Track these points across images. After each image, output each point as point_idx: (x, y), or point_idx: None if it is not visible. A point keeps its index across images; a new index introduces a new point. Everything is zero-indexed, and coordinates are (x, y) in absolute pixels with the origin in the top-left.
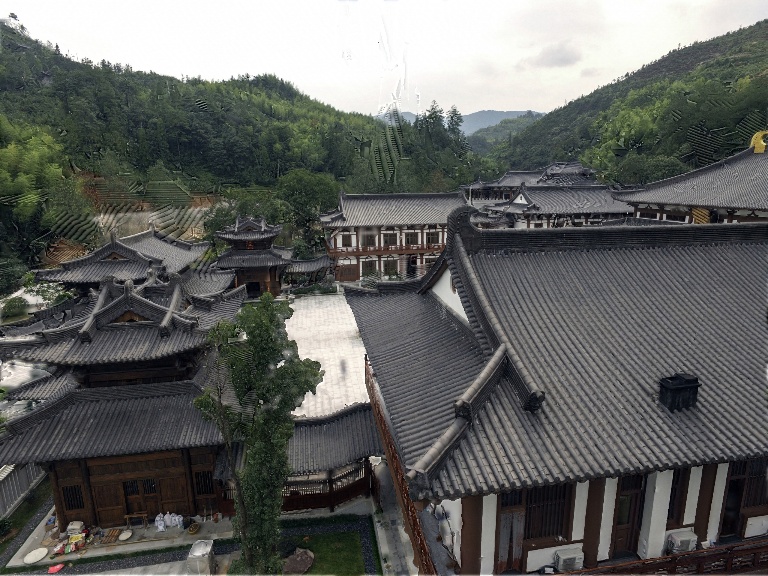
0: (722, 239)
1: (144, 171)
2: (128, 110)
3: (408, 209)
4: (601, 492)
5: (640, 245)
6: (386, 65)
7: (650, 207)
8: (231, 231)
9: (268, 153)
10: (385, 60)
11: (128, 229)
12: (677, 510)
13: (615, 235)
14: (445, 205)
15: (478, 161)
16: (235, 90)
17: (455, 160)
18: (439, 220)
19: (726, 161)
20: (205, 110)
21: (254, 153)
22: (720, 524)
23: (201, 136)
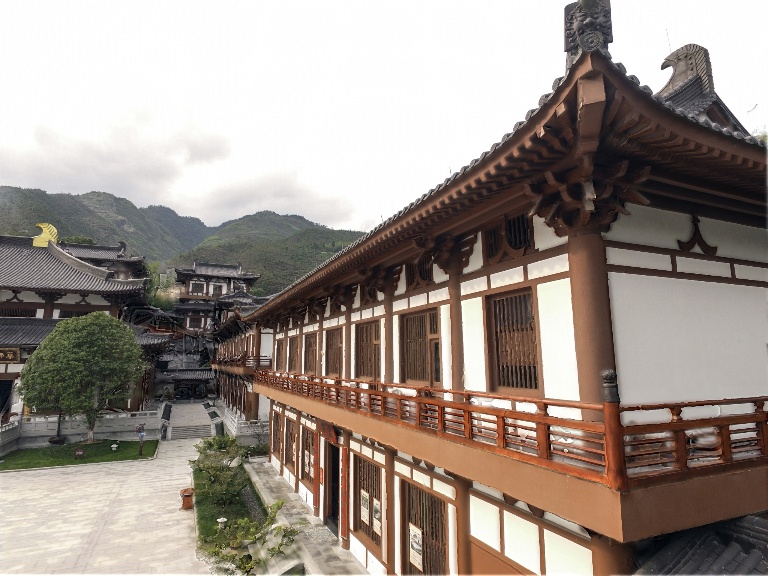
0: None
1: None
2: None
3: None
4: None
5: None
6: None
7: None
8: None
9: None
10: None
11: None
12: None
13: None
14: None
15: None
16: None
17: None
18: None
19: None
20: None
21: None
22: None
23: None
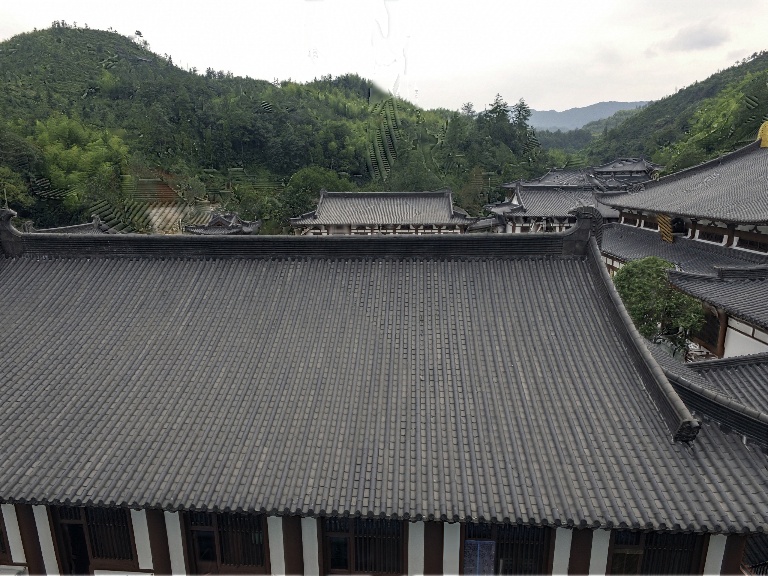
0: (300, 253)
1: (167, 169)
2: (201, 113)
3: (385, 208)
4: None
5: (198, 256)
6: (381, 61)
7: (631, 212)
8: (202, 226)
9: (323, 151)
10: (380, 56)
11: (53, 222)
12: None
13: (165, 244)
14: (426, 205)
15: (544, 157)
16: (313, 91)
17: (510, 157)
18: (411, 220)
19: (725, 158)
20: (269, 111)
21: (310, 151)
22: (60, 570)
23: (262, 136)
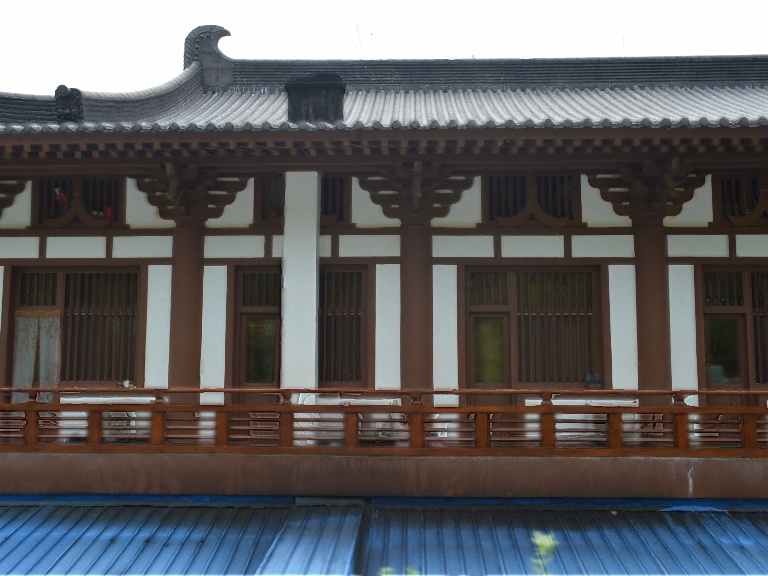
0: (651, 79)
1: None
2: None
3: None
4: (194, 291)
5: (498, 85)
6: None
7: None
8: None
9: None
10: None
11: None
12: (364, 360)
13: (452, 69)
14: None
15: None
16: None
17: None
18: None
19: None
20: None
21: None
22: (461, 402)
23: None
